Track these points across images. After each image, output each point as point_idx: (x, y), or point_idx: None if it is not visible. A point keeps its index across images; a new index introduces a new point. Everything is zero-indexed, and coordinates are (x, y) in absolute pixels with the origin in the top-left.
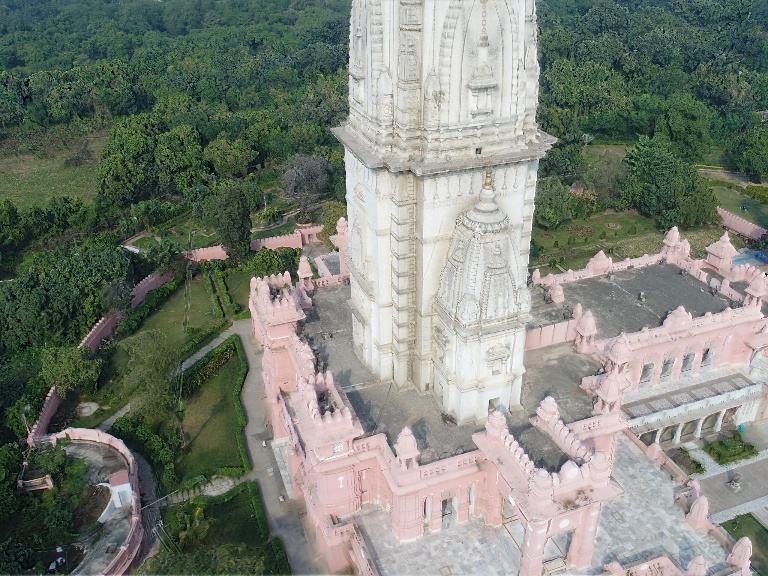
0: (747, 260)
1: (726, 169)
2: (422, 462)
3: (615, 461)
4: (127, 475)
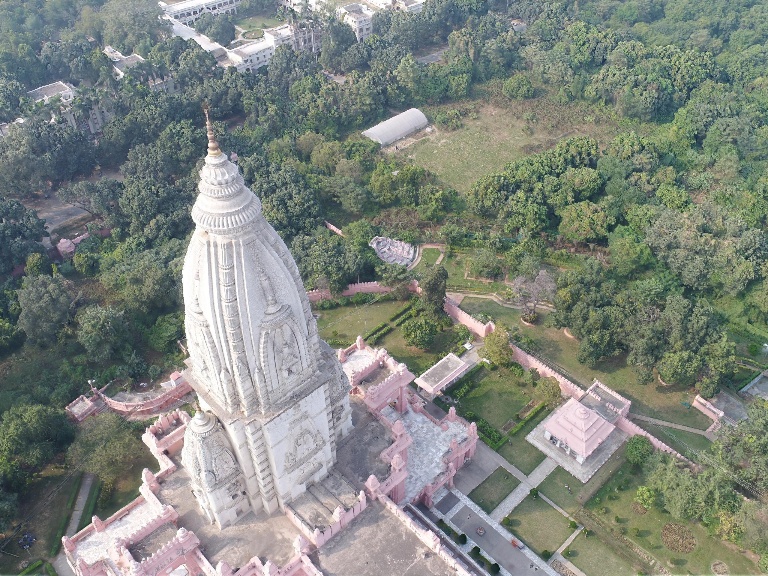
0: None
1: None
2: (161, 491)
3: None
4: (177, 377)
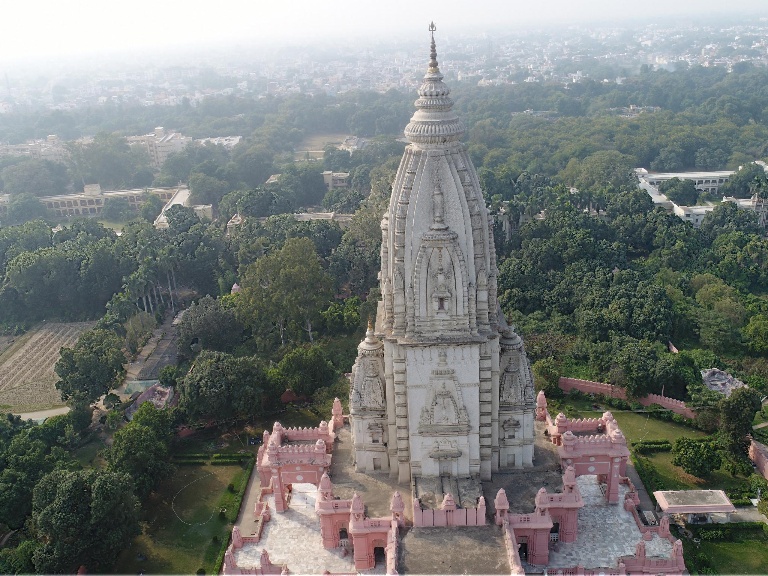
0: None
1: None
2: (341, 428)
3: (334, 557)
4: None
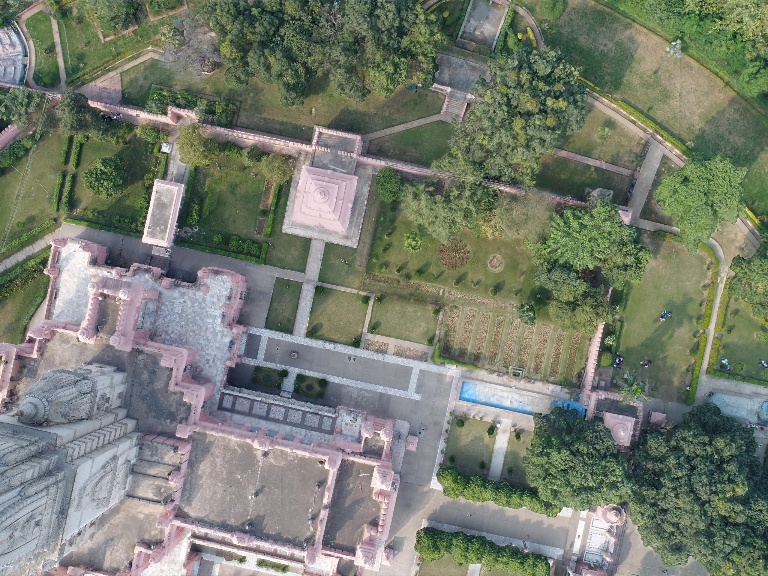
0: (541, 400)
1: (759, 228)
2: None
3: None
4: None
